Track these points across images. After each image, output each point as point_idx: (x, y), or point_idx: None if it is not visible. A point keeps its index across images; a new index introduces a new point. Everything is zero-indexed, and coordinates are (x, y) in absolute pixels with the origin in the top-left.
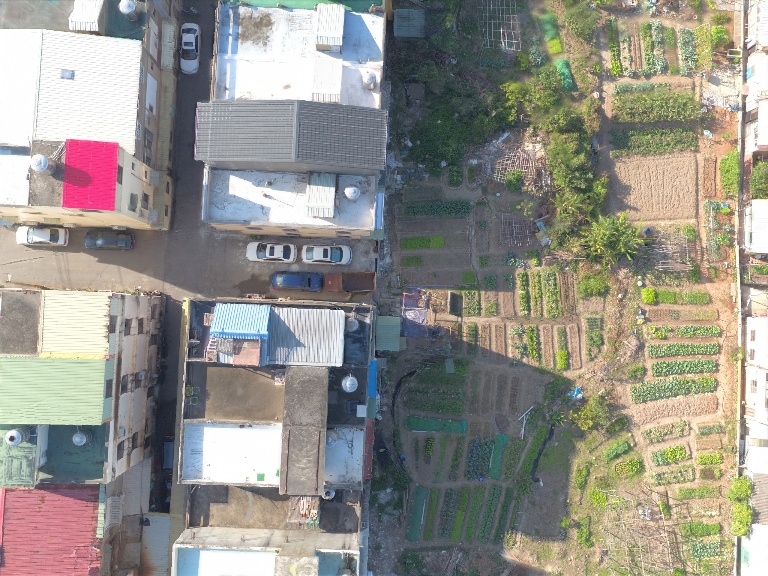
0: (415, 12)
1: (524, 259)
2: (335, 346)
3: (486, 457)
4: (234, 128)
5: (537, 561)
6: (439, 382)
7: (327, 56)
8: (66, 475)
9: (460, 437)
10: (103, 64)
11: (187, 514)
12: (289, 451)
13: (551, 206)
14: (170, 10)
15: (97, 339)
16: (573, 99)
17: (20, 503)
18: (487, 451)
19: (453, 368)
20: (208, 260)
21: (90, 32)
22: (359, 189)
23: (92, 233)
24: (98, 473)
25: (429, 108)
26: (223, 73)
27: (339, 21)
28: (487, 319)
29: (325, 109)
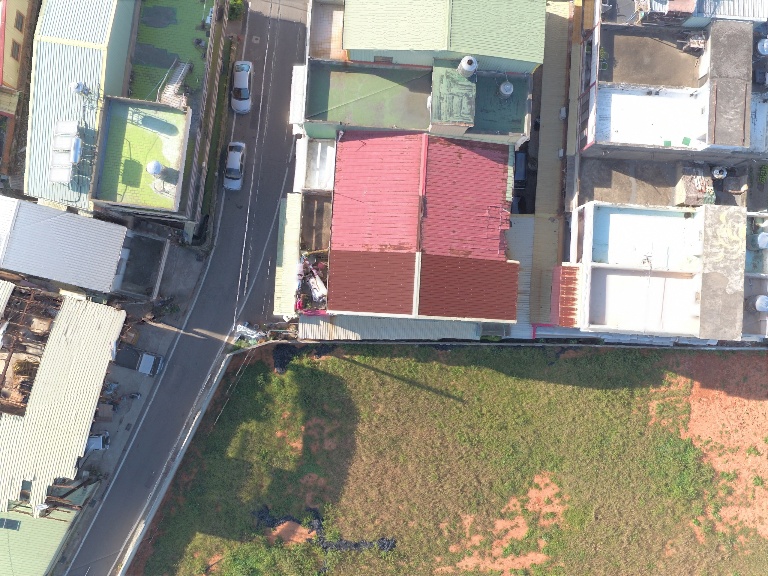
0: None
1: None
2: (760, 1)
3: None
4: None
5: None
6: None
7: None
8: None
9: None
10: None
11: (578, 193)
12: (717, 102)
13: None
14: None
15: None
16: None
17: (441, 156)
18: None
19: None
20: None
21: None
22: None
23: None
24: (514, 131)
25: None
26: None
27: None
28: None
29: None
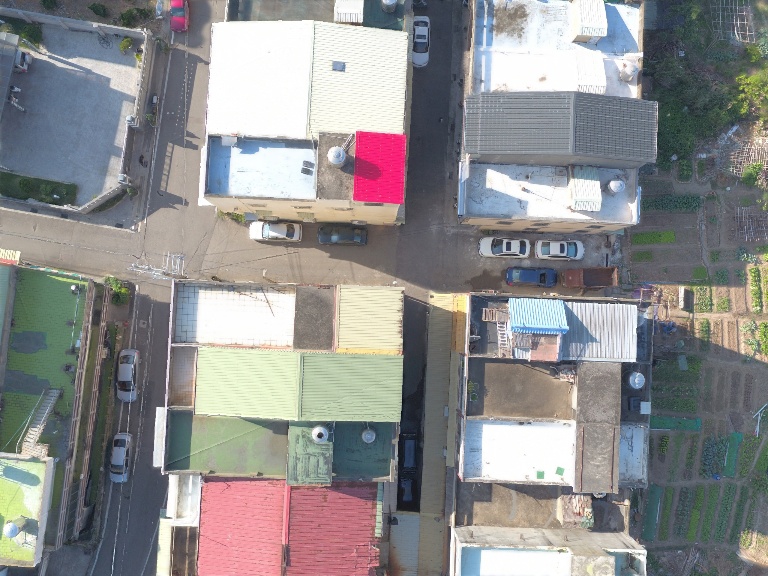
0: (647, 4)
1: (755, 254)
2: (628, 341)
3: (721, 455)
4: (506, 120)
5: None
6: (673, 379)
7: (583, 48)
8: (348, 473)
9: (695, 435)
10: (373, 56)
11: (455, 513)
12: (584, 448)
13: None
14: None
15: (391, 334)
16: None
17: (304, 501)
18: (723, 449)
19: (686, 365)
20: (440, 256)
21: (352, 24)
22: None
23: (325, 228)
24: (380, 471)
25: (658, 101)
26: (478, 65)
27: (601, 12)
28: (719, 315)
29: (600, 101)
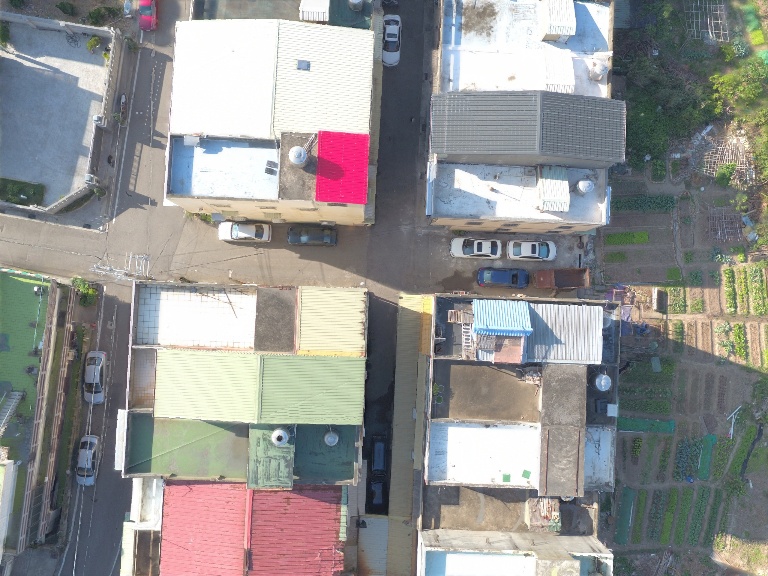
0: (620, 2)
1: (730, 255)
2: (594, 343)
3: (695, 458)
4: (472, 120)
5: (748, 564)
6: (646, 381)
7: (552, 46)
8: (312, 476)
9: (668, 437)
10: (338, 55)
11: (421, 516)
12: (548, 451)
13: (757, 200)
14: (381, 1)
15: (353, 336)
16: None
17: (267, 505)
18: (697, 452)
19: (660, 367)
20: (411, 256)
21: (318, 22)
22: (592, 182)
23: (295, 229)
24: (344, 474)
25: (631, 101)
26: (447, 64)
27: (570, 10)
28: (693, 316)
29: (567, 100)
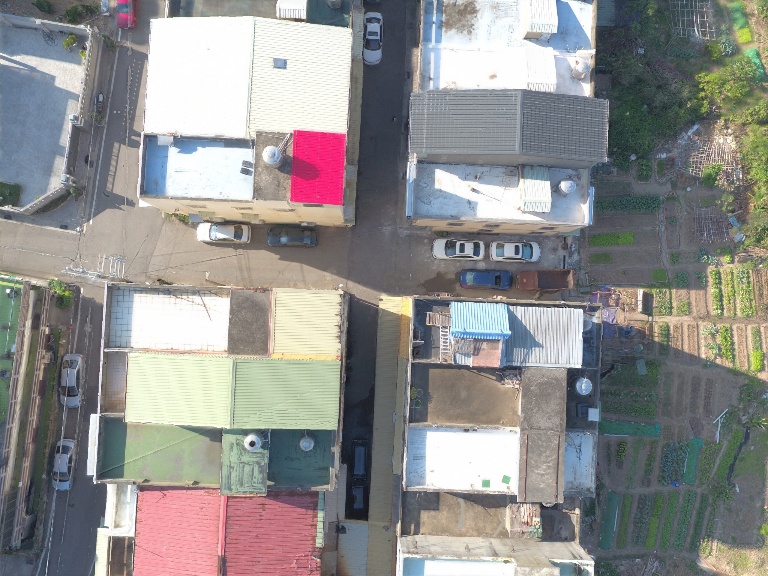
0: None
1: (716, 256)
2: (574, 346)
3: (681, 462)
4: (452, 119)
5: (734, 570)
6: (631, 384)
7: (534, 45)
8: (287, 481)
9: (654, 441)
10: (315, 53)
11: (400, 522)
12: (527, 456)
13: (744, 201)
14: None
15: (329, 339)
16: (764, 90)
17: (242, 511)
18: (682, 456)
19: (645, 369)
20: (392, 257)
21: (295, 20)
22: (575, 183)
23: (275, 230)
24: (320, 479)
25: (617, 100)
26: (427, 63)
27: (551, 8)
28: (679, 318)
29: (548, 99)
